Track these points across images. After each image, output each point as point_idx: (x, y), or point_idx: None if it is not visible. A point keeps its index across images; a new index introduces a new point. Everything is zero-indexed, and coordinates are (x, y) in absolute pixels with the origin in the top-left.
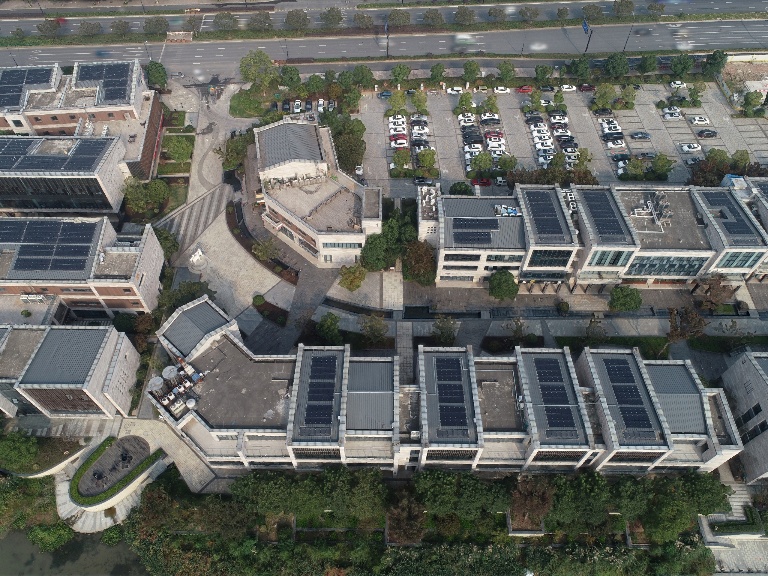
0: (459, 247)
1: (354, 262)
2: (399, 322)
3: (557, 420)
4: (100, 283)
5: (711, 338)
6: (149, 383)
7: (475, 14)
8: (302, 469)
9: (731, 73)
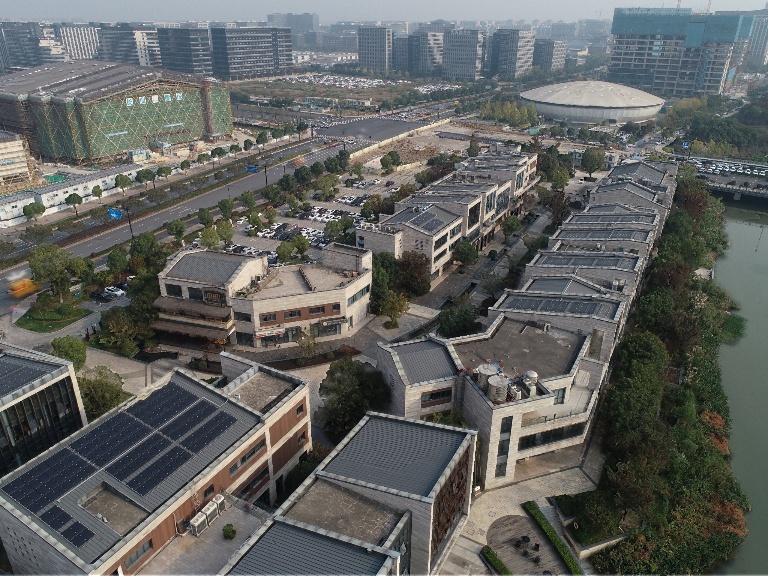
0: (437, 232)
1: (365, 316)
2: None
3: None
4: (277, 412)
5: None
6: (495, 385)
7: (165, 191)
8: (607, 380)
9: None
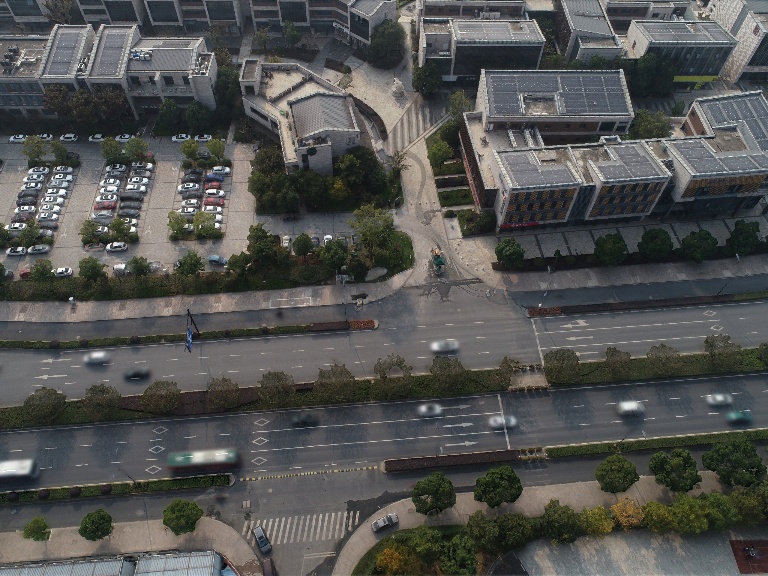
0: (189, 40)
1: None
2: None
3: None
4: None
5: None
6: None
7: None
8: None
9: None
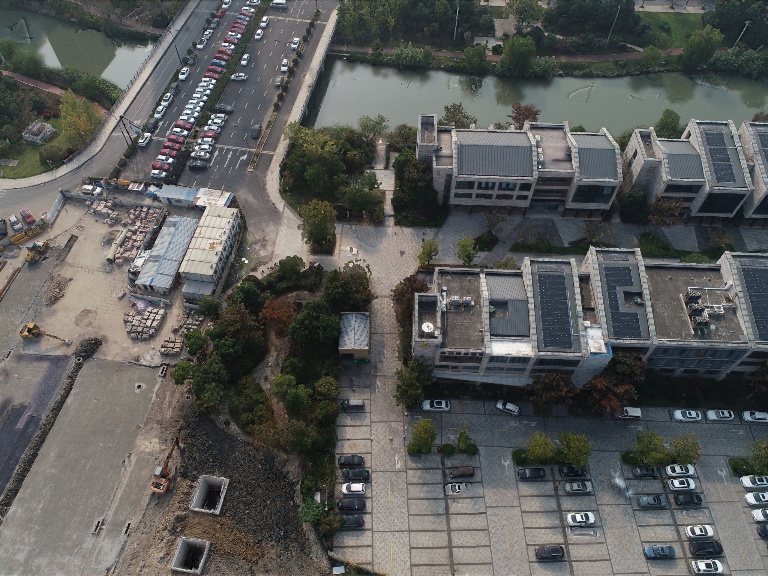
0: None
1: None
2: None
3: None
4: None
5: None
6: None
7: None
8: None
9: None
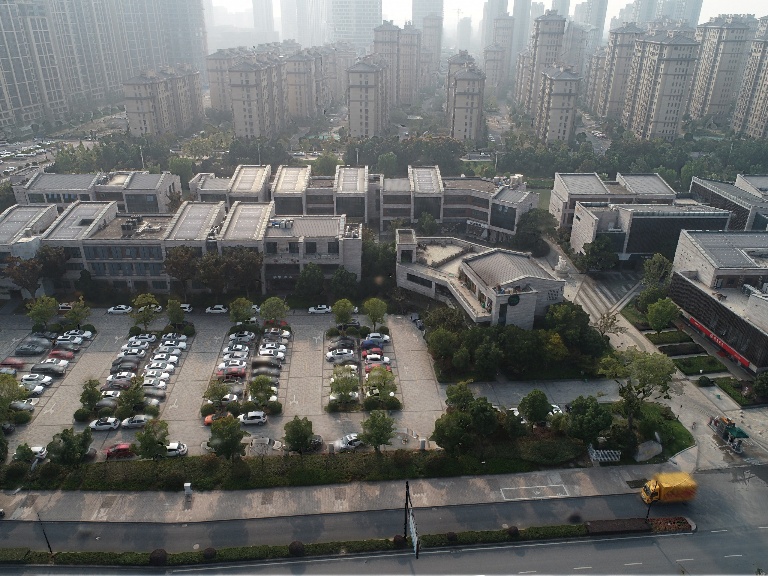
0: (330, 216)
1: None
2: None
3: (295, 171)
4: None
5: None
6: None
7: None
8: None
9: None
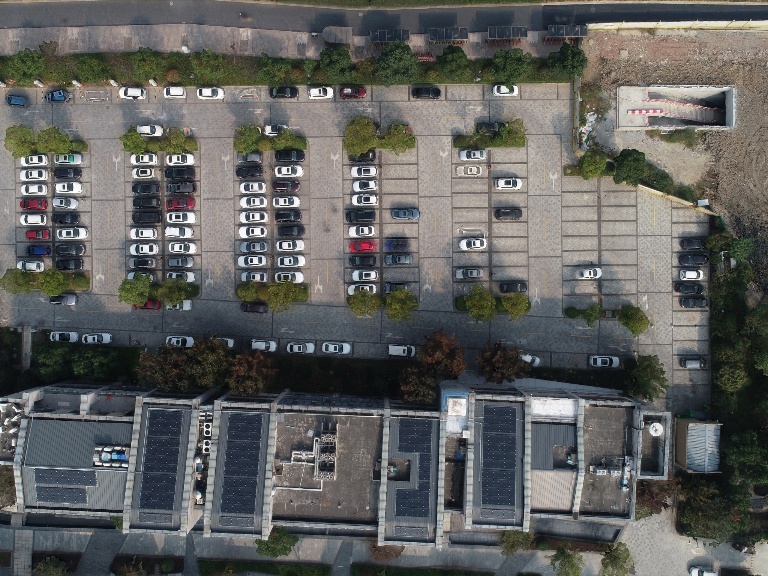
0: (44, 507)
1: None
2: (18, 531)
3: None
4: None
5: (378, 572)
6: None
7: None
8: None
9: (608, 58)
